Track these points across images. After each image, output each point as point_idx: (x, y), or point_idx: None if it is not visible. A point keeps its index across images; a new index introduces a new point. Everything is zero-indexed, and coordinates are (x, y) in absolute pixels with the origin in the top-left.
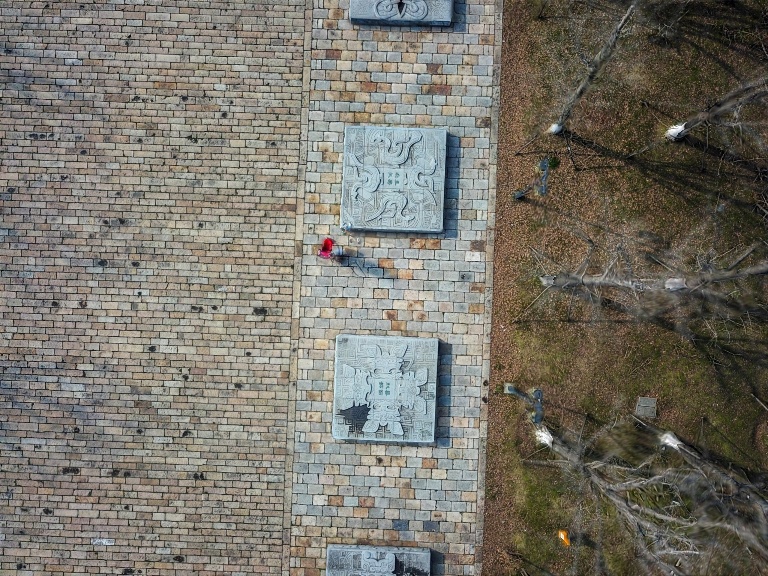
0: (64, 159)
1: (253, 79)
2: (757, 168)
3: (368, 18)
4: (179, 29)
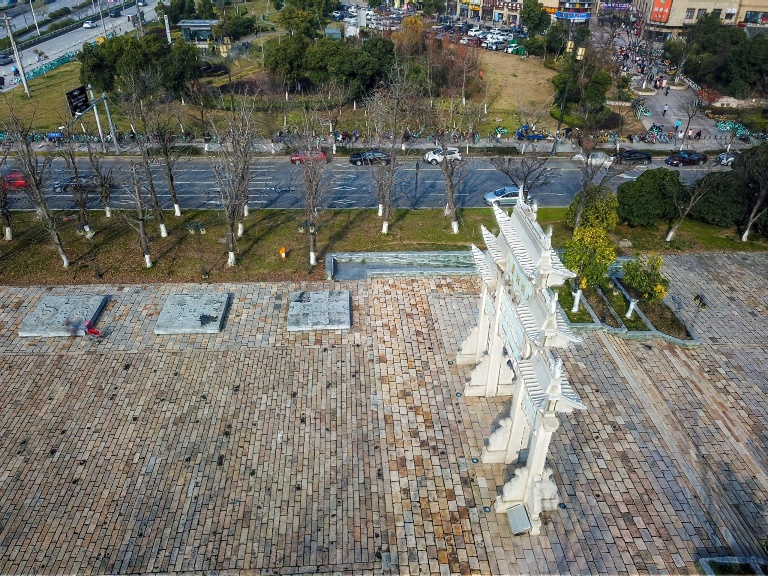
0: None
1: None
2: None
3: None
4: None
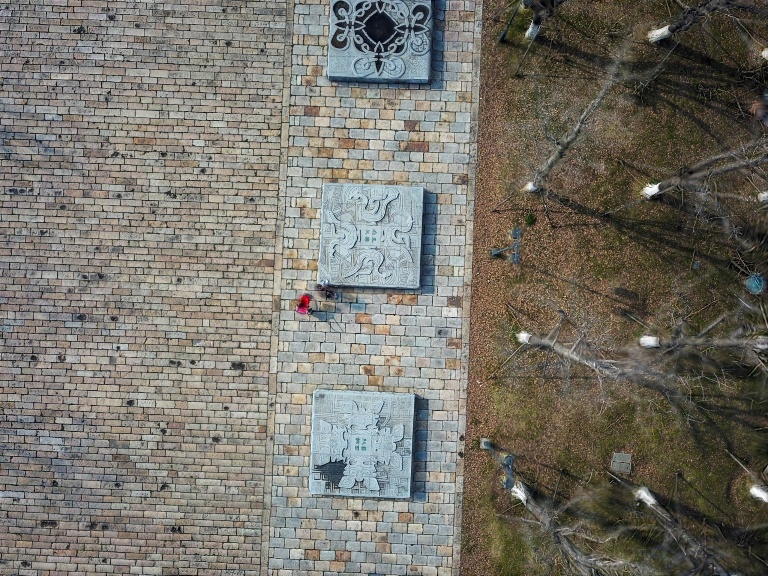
0: (44, 214)
1: (232, 135)
2: (732, 225)
3: (346, 76)
4: (158, 85)
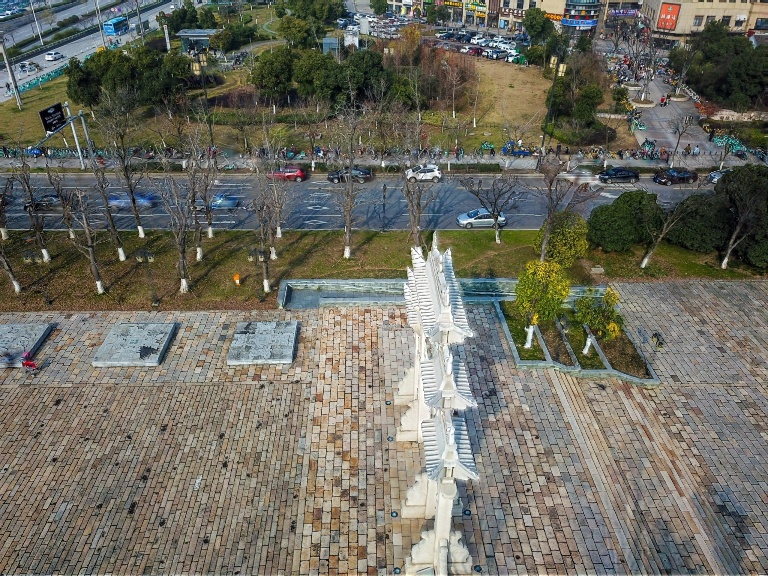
0: None
1: None
2: None
3: None
4: None
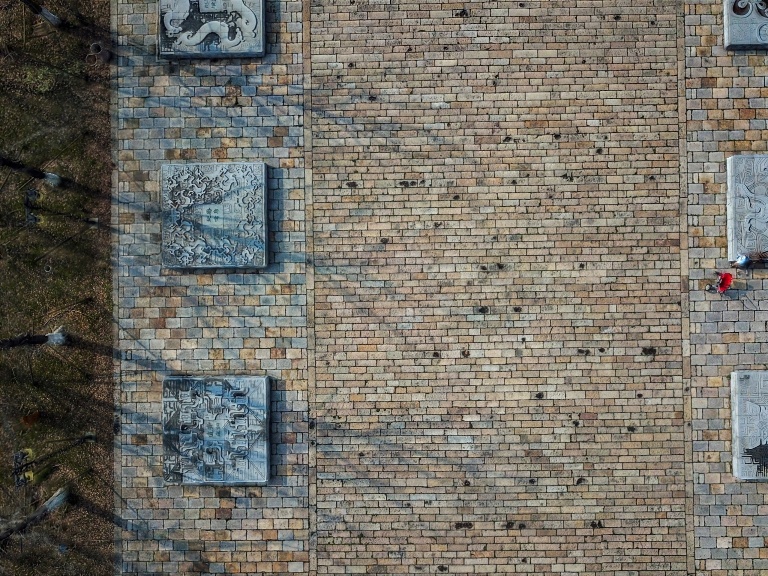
0: (437, 205)
1: (627, 112)
2: None
3: (750, 43)
4: (548, 65)
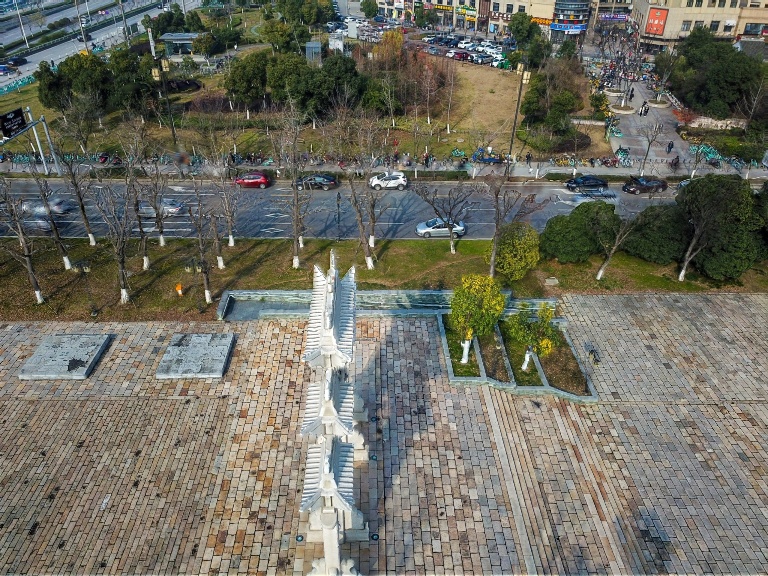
0: None
1: None
2: None
3: None
4: None
